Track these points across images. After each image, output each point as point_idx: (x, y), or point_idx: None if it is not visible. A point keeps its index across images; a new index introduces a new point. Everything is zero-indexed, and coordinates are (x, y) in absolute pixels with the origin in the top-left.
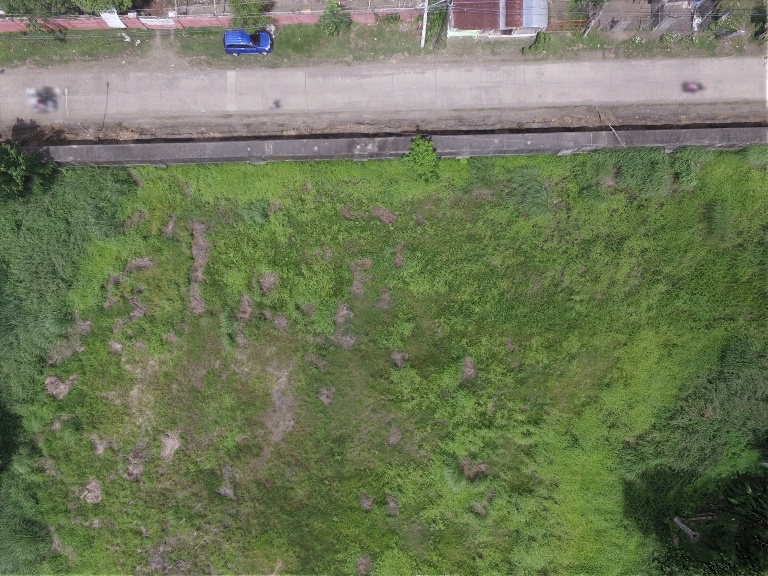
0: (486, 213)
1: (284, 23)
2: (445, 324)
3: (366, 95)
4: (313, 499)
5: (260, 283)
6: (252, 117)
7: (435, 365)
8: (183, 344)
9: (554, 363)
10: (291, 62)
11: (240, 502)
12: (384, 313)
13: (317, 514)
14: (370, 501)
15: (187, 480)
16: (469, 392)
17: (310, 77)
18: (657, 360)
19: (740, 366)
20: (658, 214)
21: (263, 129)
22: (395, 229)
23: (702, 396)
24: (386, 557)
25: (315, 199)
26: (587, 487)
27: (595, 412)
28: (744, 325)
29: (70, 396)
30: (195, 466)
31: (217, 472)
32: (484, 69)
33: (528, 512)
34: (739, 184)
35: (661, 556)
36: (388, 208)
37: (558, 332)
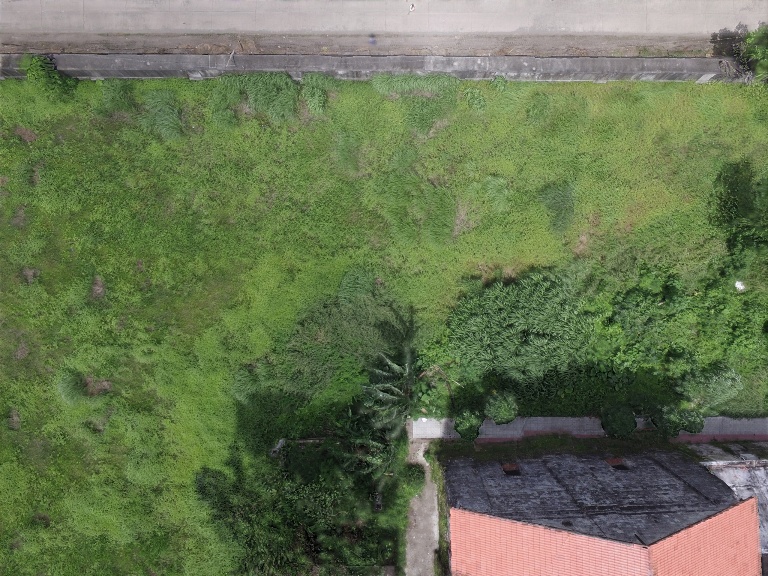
0: (122, 135)
1: None
2: (76, 242)
3: (15, 17)
4: None
5: None
6: None
7: (64, 282)
8: None
9: (180, 284)
10: None
11: None
12: (18, 230)
13: None
14: None
15: None
16: (95, 310)
17: None
18: (279, 284)
19: (352, 291)
20: (290, 141)
21: None
22: (33, 148)
23: (317, 320)
24: (3, 469)
25: None
26: (203, 407)
27: (216, 334)
28: (369, 253)
29: None
30: None
31: None
32: None
33: (145, 430)
34: (370, 114)
35: (268, 478)
36: (28, 127)
37: (185, 254)
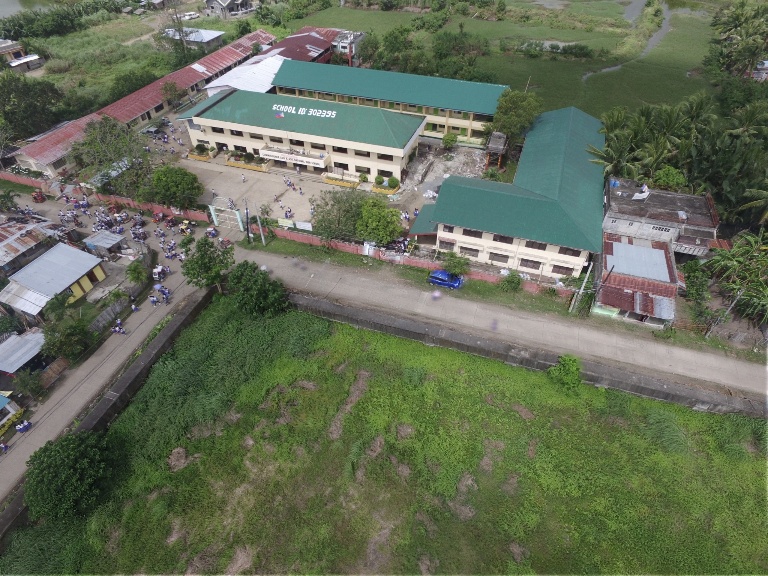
0: (623, 437)
1: (470, 277)
2: (576, 532)
3: (521, 328)
4: None
5: (397, 430)
6: (430, 319)
7: None
8: (307, 460)
9: None
10: (469, 297)
11: None
12: (510, 497)
13: None
14: None
15: None
16: None
17: (480, 308)
18: None
19: None
20: None
21: None
22: (532, 425)
23: None
24: None
25: (465, 381)
26: None
27: None
28: None
29: (185, 470)
30: None
31: None
32: (620, 336)
33: None
34: None
35: None
36: (528, 407)
37: None
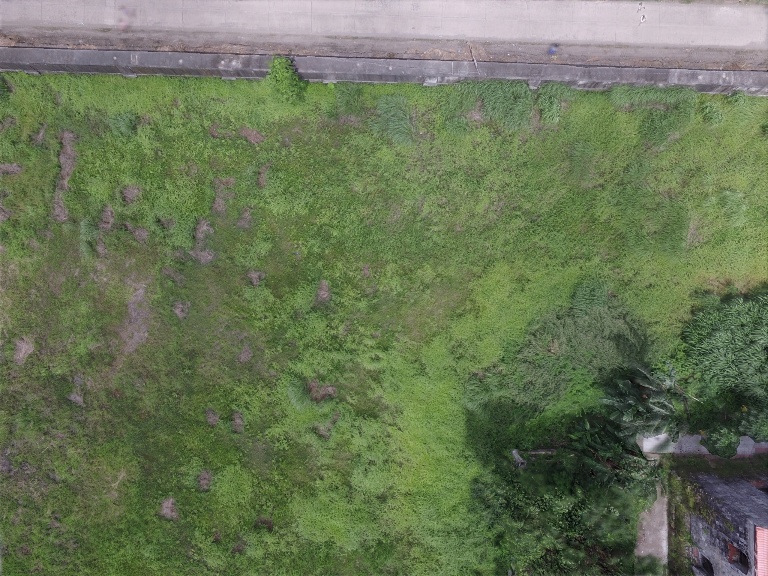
0: (351, 139)
1: None
2: (303, 246)
3: (242, 17)
4: (161, 411)
5: (123, 194)
6: (129, 32)
7: (290, 286)
8: (44, 250)
9: (408, 291)
10: None
11: (89, 409)
12: (244, 231)
13: (163, 426)
14: (217, 417)
15: (39, 384)
16: (322, 314)
17: None
18: (509, 294)
19: (588, 303)
20: (521, 150)
21: (139, 44)
22: (260, 149)
23: (550, 331)
24: (227, 472)
25: (183, 115)
26: (431, 416)
27: (445, 342)
28: (600, 265)
29: None
30: (47, 371)
31: (69, 378)
32: None
33: (371, 437)
34: (603, 125)
35: (499, 488)
36: (255, 129)
37: (414, 260)
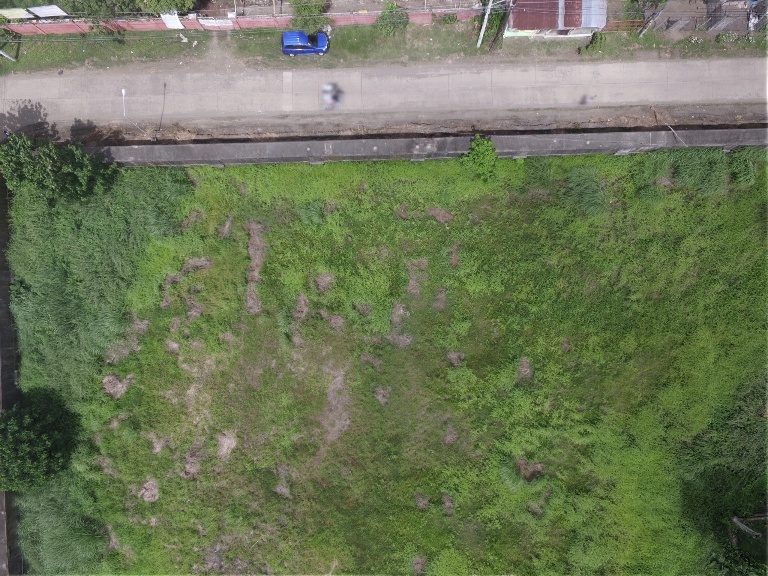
0: (542, 213)
1: (340, 24)
2: (501, 324)
3: (422, 95)
4: (369, 498)
5: (317, 283)
6: (308, 117)
7: (491, 365)
8: (240, 343)
9: (611, 363)
10: (347, 62)
11: (297, 501)
12: (440, 313)
13: (373, 513)
14: (426, 500)
15: (244, 479)
16: (526, 392)
17: (366, 77)
18: (714, 360)
19: None
20: (715, 214)
21: (319, 129)
22: (451, 229)
23: (760, 396)
24: (443, 556)
25: (372, 199)
26: (644, 487)
27: (652, 412)
28: None
29: (128, 395)
30: (252, 465)
31: (273, 471)
32: (540, 69)
33: (585, 512)
34: None
35: (720, 556)
36: (444, 208)
37: (615, 332)
